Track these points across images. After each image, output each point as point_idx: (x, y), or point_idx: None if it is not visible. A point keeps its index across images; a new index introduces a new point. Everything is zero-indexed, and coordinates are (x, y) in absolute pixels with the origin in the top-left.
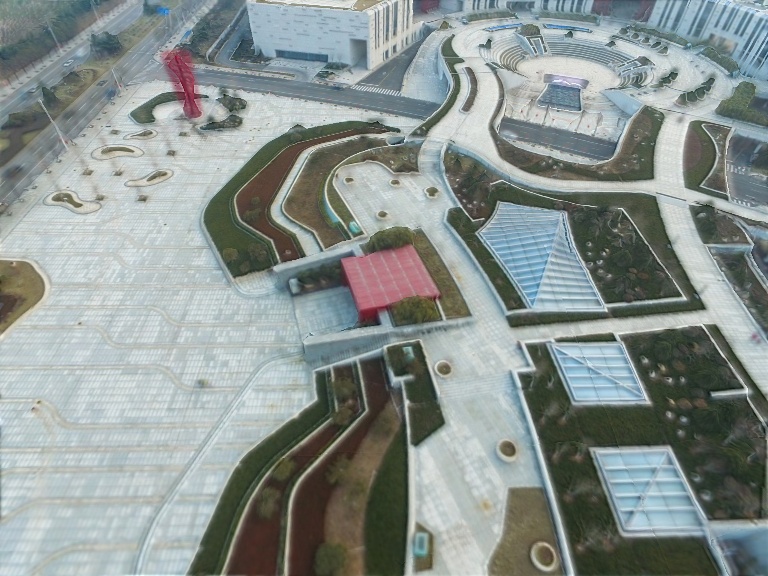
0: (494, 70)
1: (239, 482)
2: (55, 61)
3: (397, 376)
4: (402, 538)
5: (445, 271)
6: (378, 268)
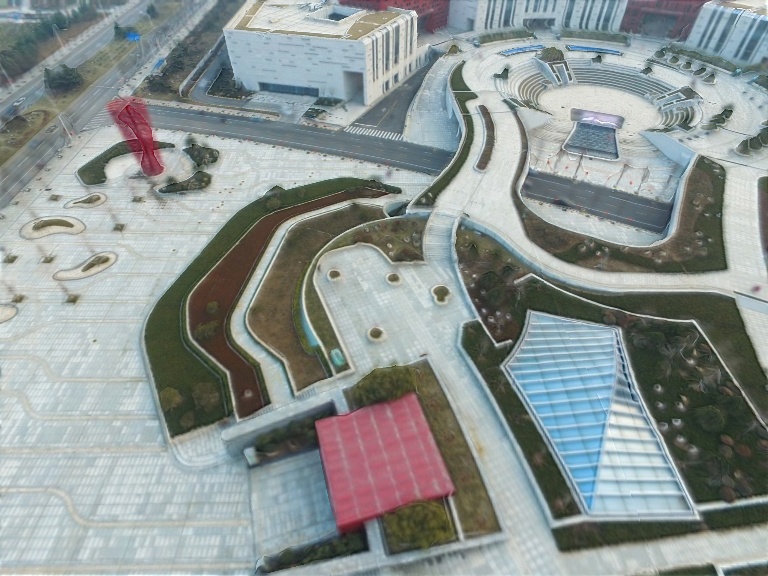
0: (513, 109)
1: None
2: (4, 99)
3: None
4: None
5: (460, 439)
6: (366, 439)
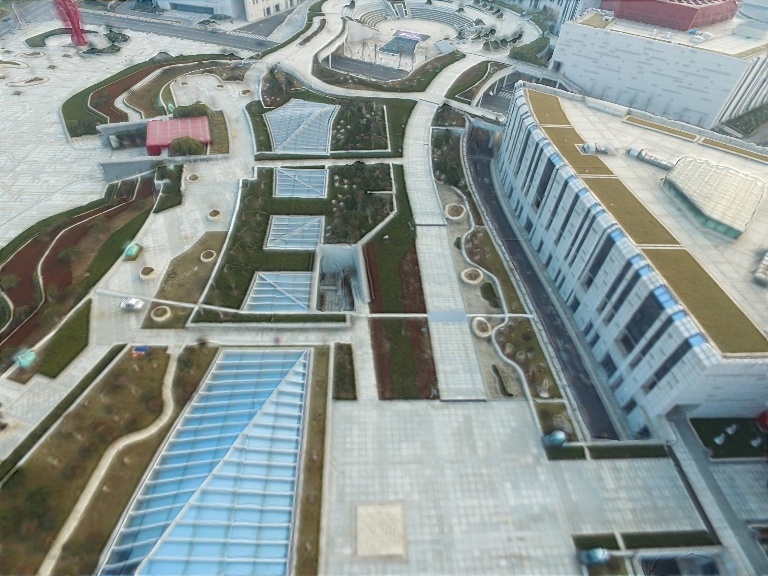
0: (344, 21)
1: (30, 231)
2: None
3: (158, 180)
4: (123, 249)
5: (225, 132)
6: (173, 127)
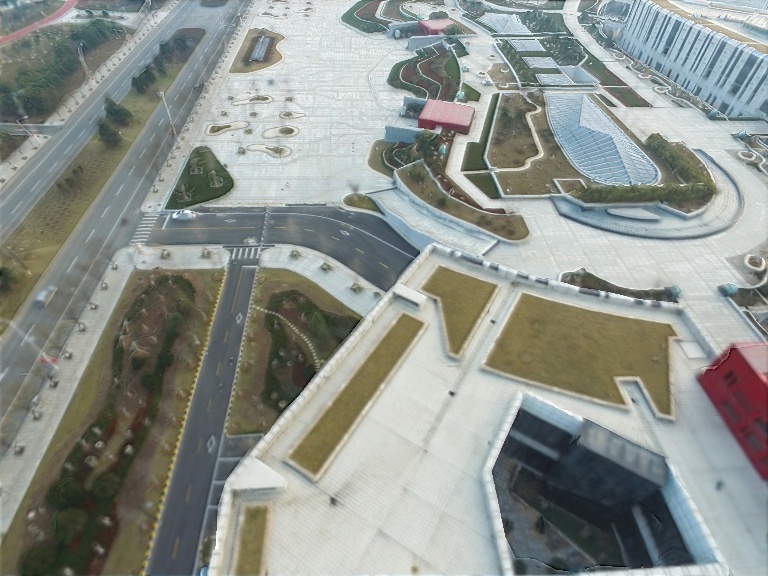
0: None
1: None
2: None
3: (449, 44)
4: (458, 69)
5: (464, 26)
6: (435, 22)
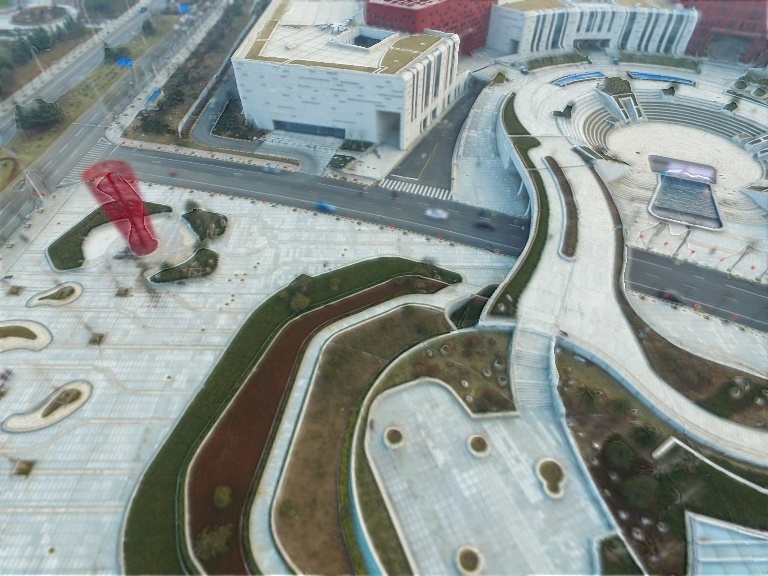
0: (589, 162)
1: None
2: None
3: None
4: None
5: None
6: None
